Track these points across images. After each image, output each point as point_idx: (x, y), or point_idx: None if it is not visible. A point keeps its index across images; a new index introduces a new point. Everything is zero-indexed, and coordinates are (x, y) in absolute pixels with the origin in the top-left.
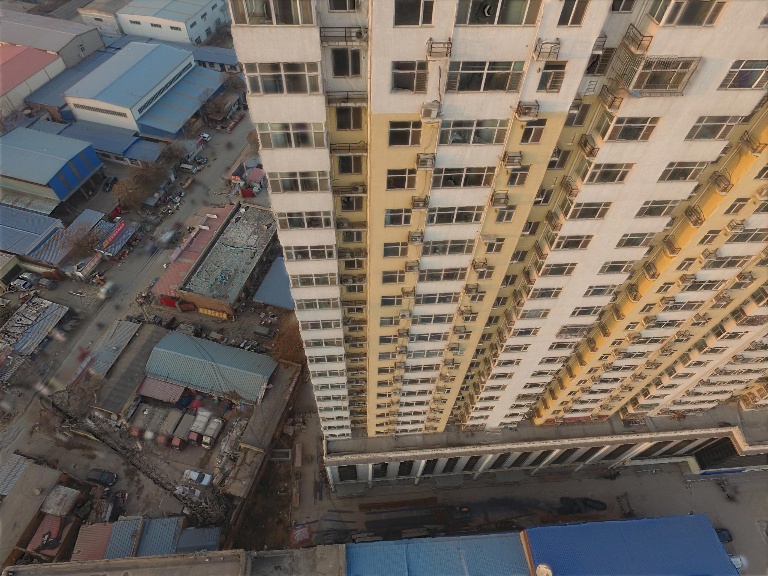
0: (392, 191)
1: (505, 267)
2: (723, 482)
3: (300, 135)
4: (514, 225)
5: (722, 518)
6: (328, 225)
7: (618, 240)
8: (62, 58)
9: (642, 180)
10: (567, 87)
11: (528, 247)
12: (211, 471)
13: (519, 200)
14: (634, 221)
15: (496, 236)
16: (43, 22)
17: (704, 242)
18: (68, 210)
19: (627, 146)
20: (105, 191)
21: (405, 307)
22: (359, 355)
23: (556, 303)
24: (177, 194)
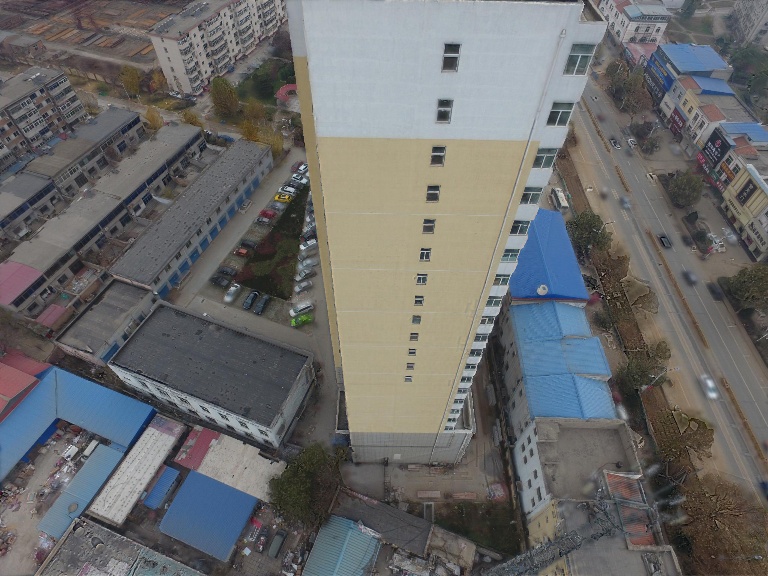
0: None
1: None
2: None
3: None
4: None
5: None
6: None
7: None
8: None
9: None
10: None
11: None
12: None
13: None
14: None
15: None
16: None
17: None
18: None
19: None
20: None
21: None
22: None
23: None
24: None
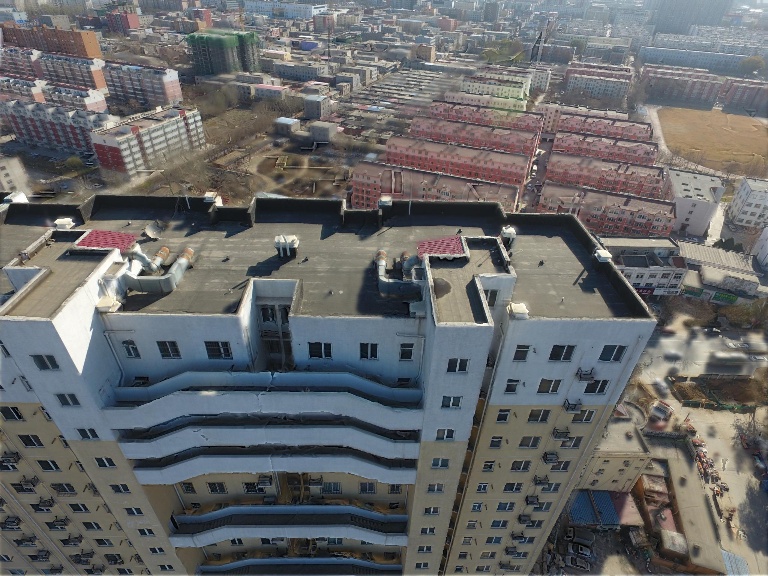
0: None
1: None
2: None
3: None
4: None
5: None
6: None
7: None
8: None
9: None
10: None
11: None
12: (568, 570)
13: None
14: None
15: None
16: None
17: None
18: None
19: None
20: None
21: None
22: None
23: None
24: None
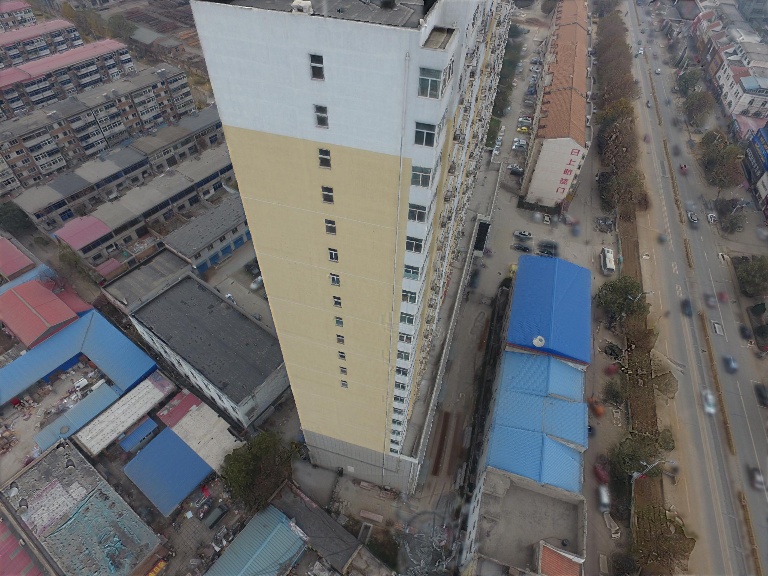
0: (446, 171)
1: None
2: (487, 250)
3: None
4: None
5: (505, 262)
6: None
7: None
8: None
9: None
10: None
11: None
12: None
13: None
14: None
15: None
16: None
17: None
18: None
19: None
20: None
21: None
22: None
23: None
24: None
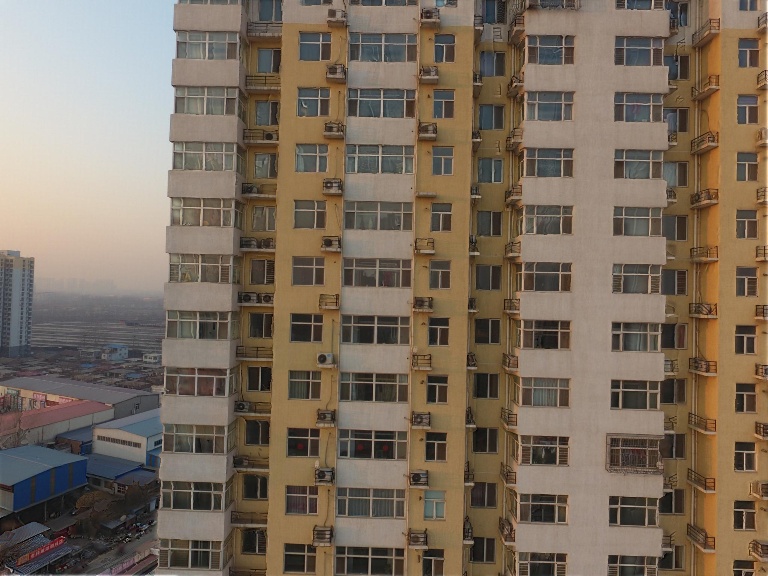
0: (303, 117)
1: (465, 263)
2: None
3: (215, 47)
4: (457, 180)
5: None
6: (229, 169)
7: (611, 218)
8: (115, 410)
9: (594, 116)
10: (463, 2)
11: (497, 258)
12: None
13: (453, 139)
14: (617, 183)
15: (438, 199)
16: (118, 389)
17: (745, 235)
18: (13, 528)
19: (553, 69)
20: (70, 515)
21: (327, 347)
22: (256, 517)
23: (572, 363)
24: (147, 521)
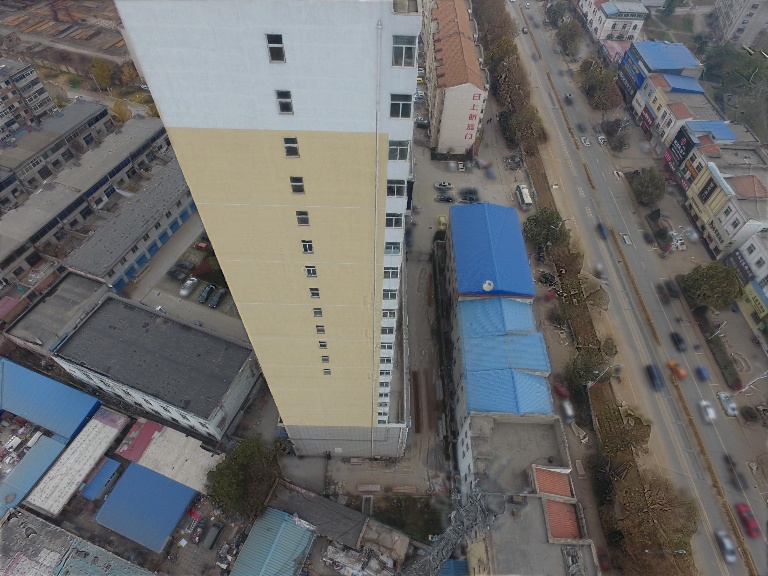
0: None
1: None
2: (413, 207)
3: None
4: None
5: (433, 216)
6: None
7: None
8: None
9: None
10: None
11: None
12: None
13: None
14: None
15: None
16: None
17: None
18: None
19: None
20: None
21: None
22: None
23: None
24: None
